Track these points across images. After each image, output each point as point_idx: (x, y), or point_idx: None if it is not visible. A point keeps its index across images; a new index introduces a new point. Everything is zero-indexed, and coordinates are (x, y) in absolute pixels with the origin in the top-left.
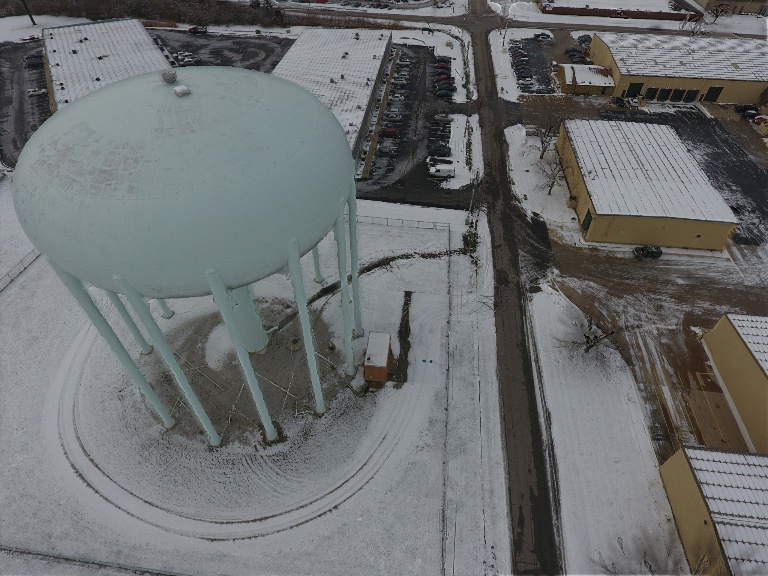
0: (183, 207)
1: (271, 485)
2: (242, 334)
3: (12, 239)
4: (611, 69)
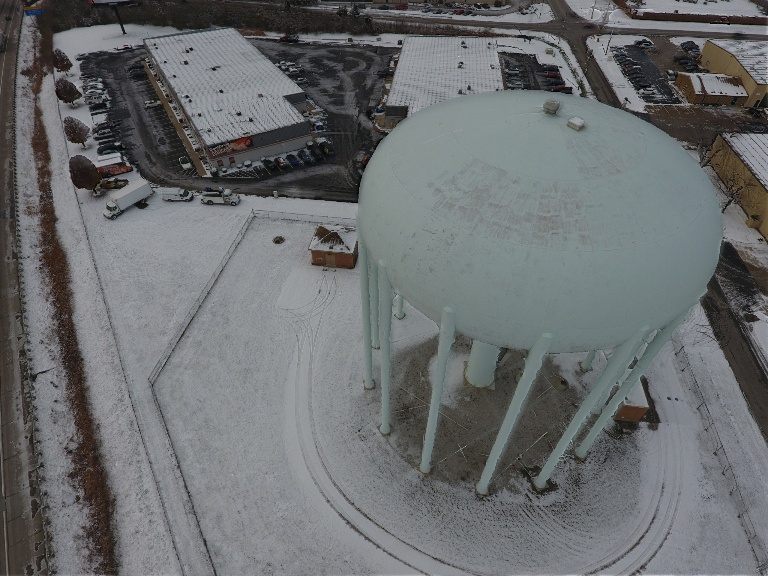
0: (639, 259)
1: (562, 541)
2: (479, 369)
3: (183, 261)
4: (740, 78)
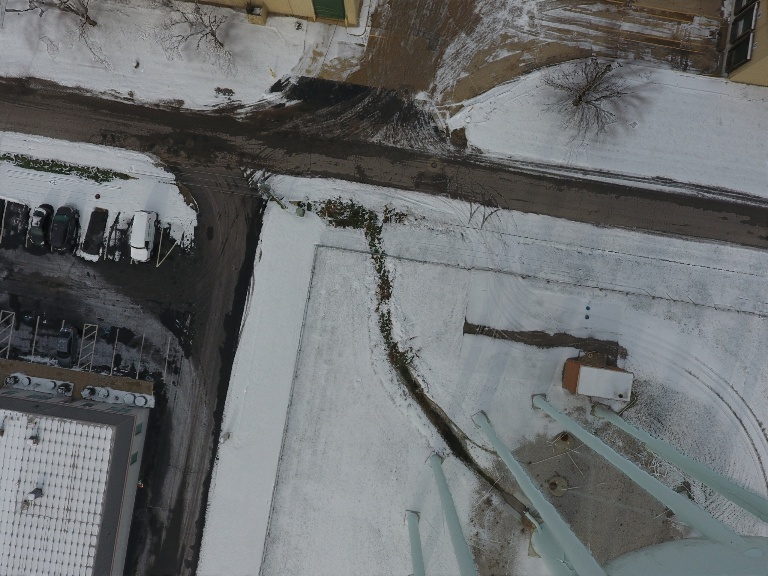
0: None
1: None
2: None
3: None
4: None
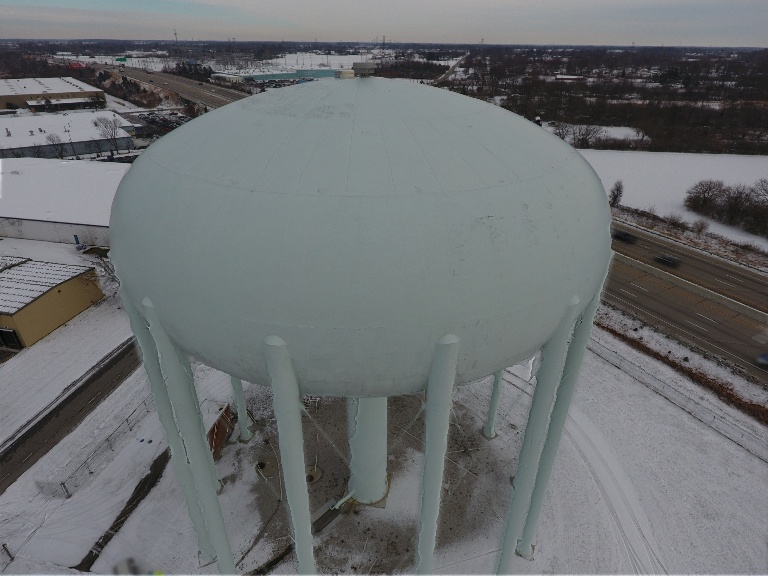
0: None
1: None
2: None
3: None
4: None
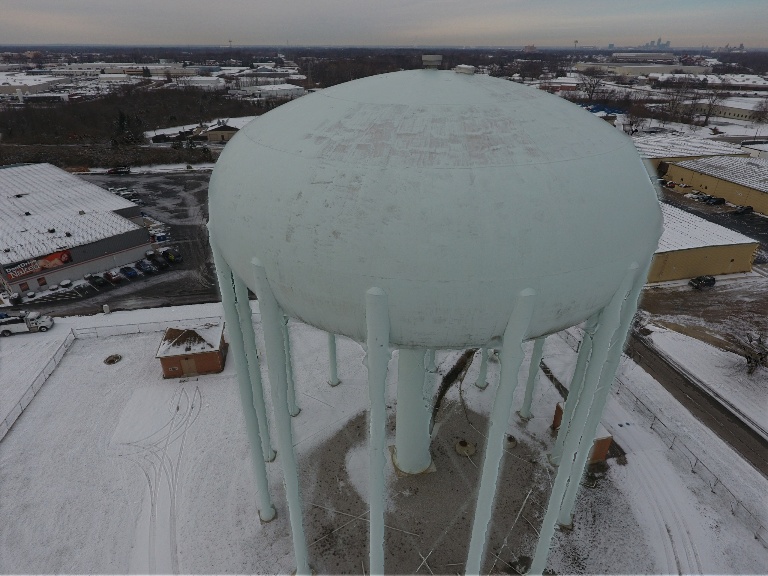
0: (603, 171)
1: None
2: (413, 446)
3: None
4: None
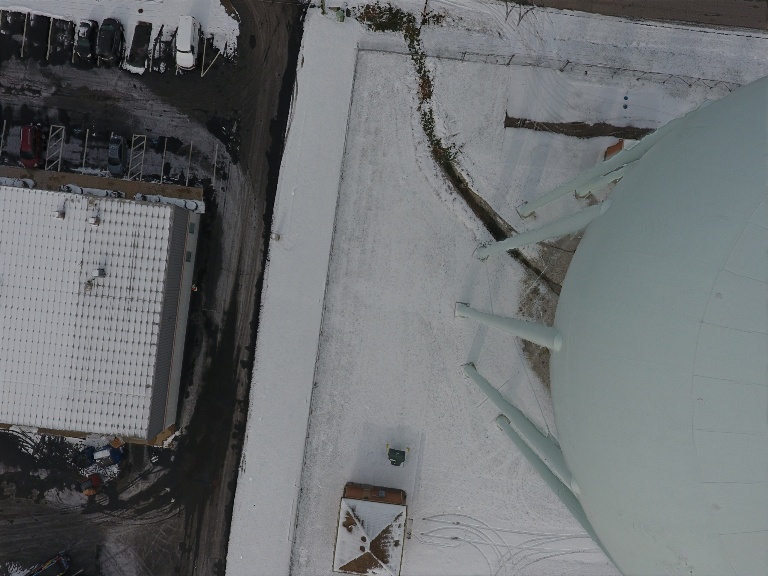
0: None
1: None
2: None
3: None
4: None
